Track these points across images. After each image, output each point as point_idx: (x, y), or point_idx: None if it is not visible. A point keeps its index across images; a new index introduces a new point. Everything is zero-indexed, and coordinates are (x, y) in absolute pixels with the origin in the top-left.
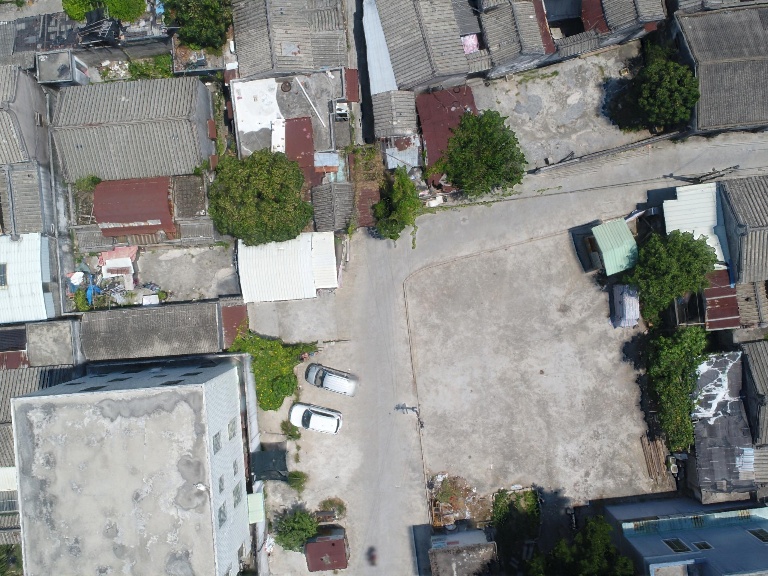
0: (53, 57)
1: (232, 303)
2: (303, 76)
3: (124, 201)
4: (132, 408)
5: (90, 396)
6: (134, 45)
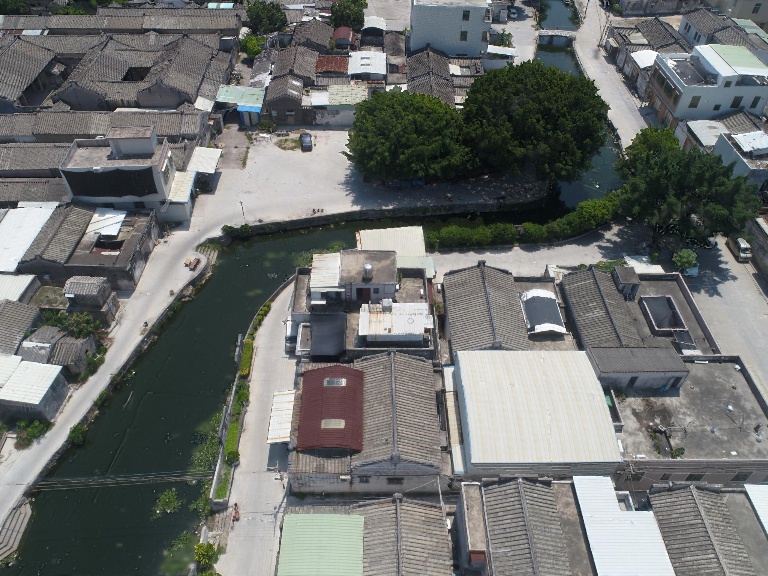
0: None
1: None
2: None
3: None
4: None
5: None
6: None
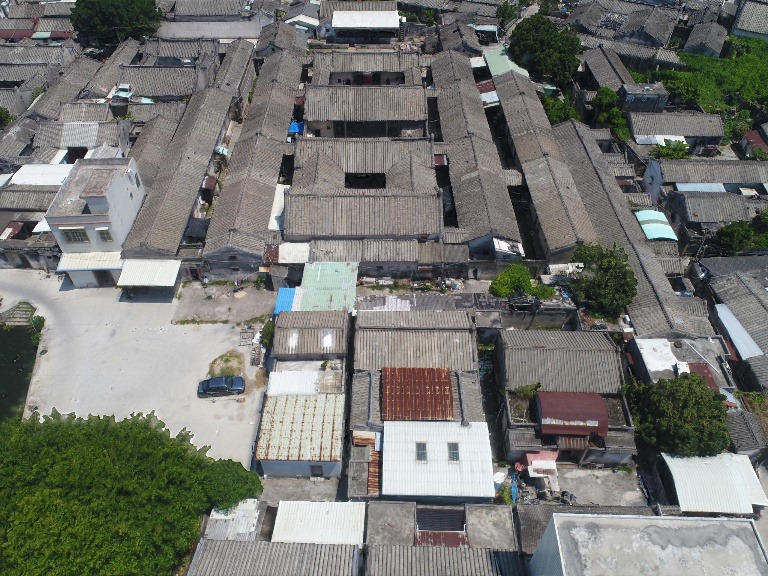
0: (487, 314)
1: (667, 510)
2: (689, 340)
3: (567, 402)
4: (681, 537)
5: (634, 520)
6: (546, 314)
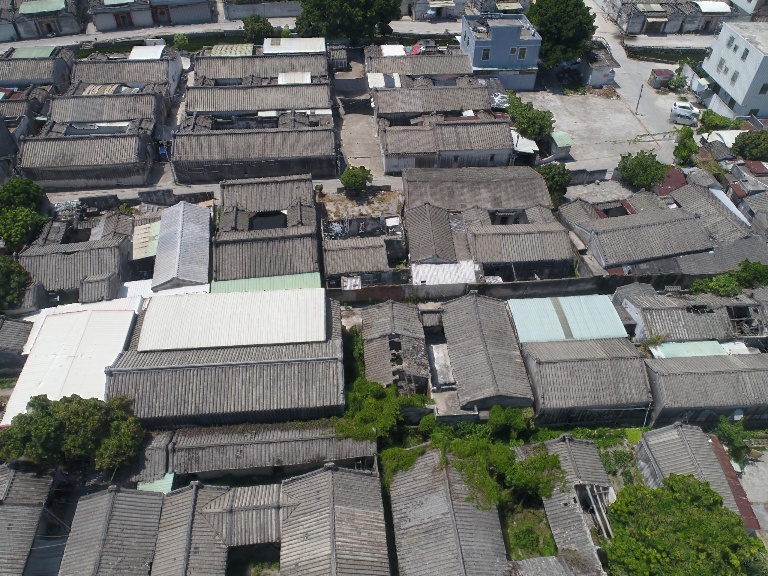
0: None
1: None
2: None
3: None
4: None
5: None
6: None
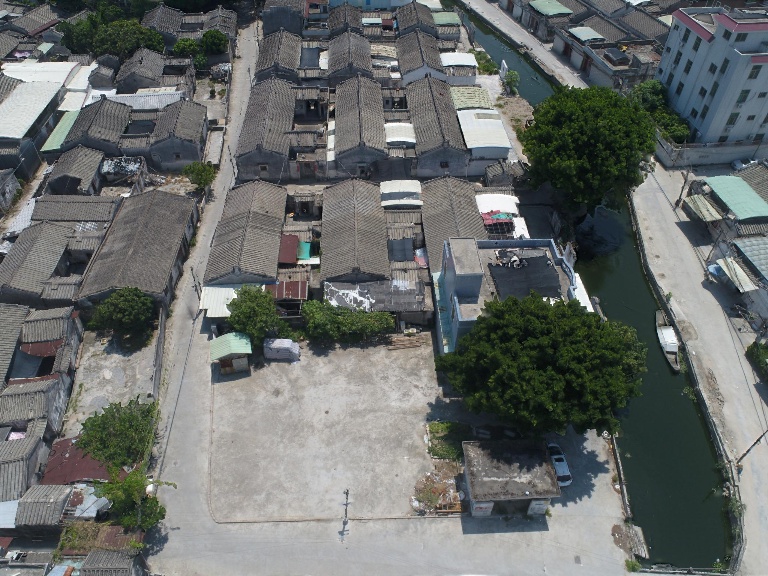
0: None
1: None
2: None
3: None
4: None
5: None
6: None
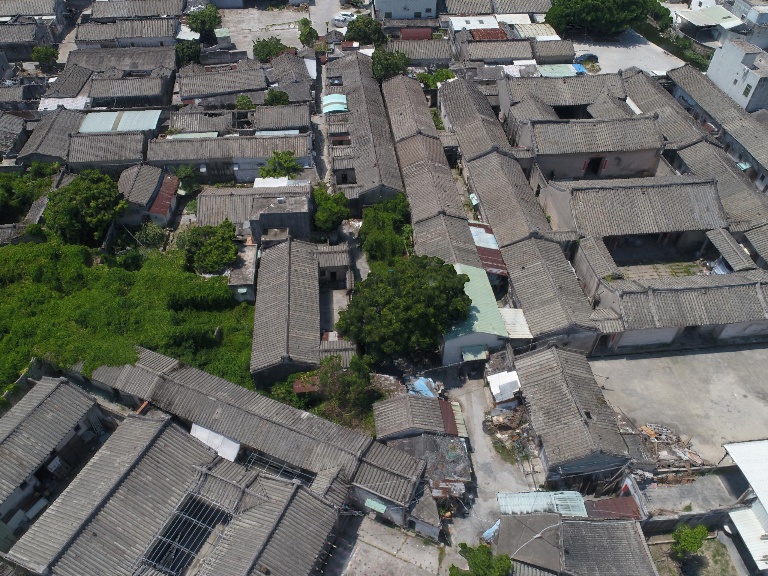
0: None
1: None
2: None
3: None
4: None
5: None
6: None
